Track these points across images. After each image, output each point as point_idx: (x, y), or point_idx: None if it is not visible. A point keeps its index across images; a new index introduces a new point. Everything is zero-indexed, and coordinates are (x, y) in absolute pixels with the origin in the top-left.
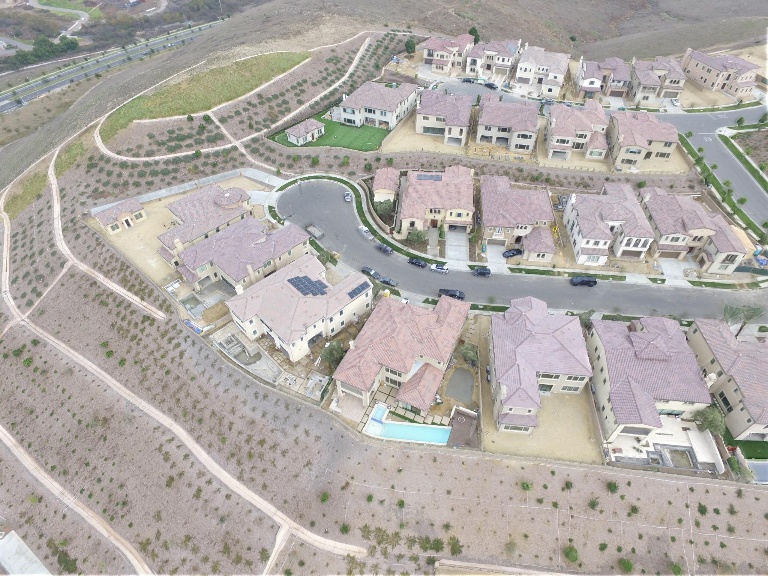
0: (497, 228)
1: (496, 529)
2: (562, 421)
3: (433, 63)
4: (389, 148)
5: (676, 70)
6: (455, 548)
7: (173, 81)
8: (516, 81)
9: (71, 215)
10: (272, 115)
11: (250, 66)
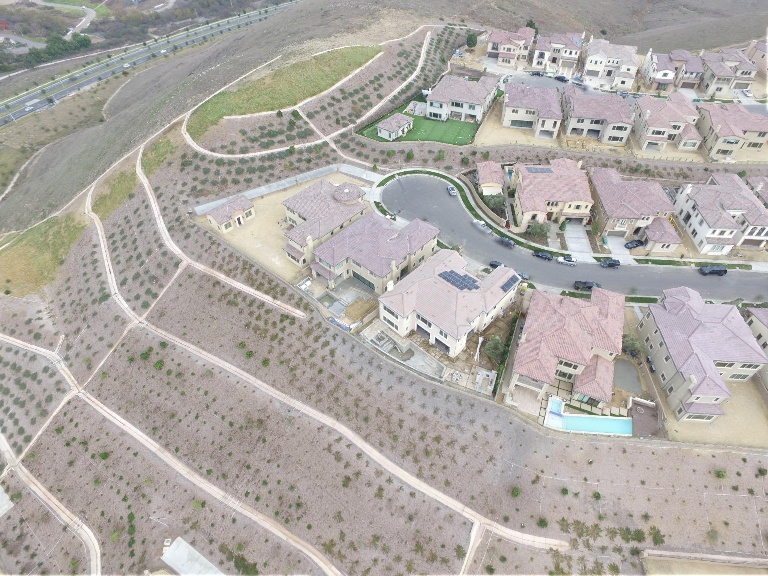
0: (621, 219)
1: (695, 518)
2: (738, 409)
3: (500, 56)
4: (481, 142)
5: (747, 61)
6: (657, 538)
7: (255, 76)
8: (585, 74)
9: (174, 214)
10: (356, 110)
11: (328, 60)
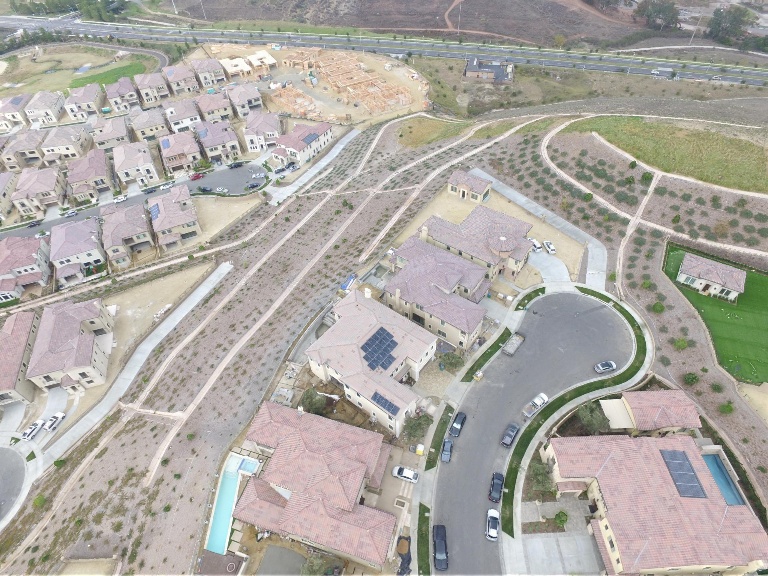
0: None
1: None
2: None
3: None
4: (766, 400)
5: None
6: None
7: (684, 124)
8: None
9: (467, 161)
10: (719, 230)
11: None
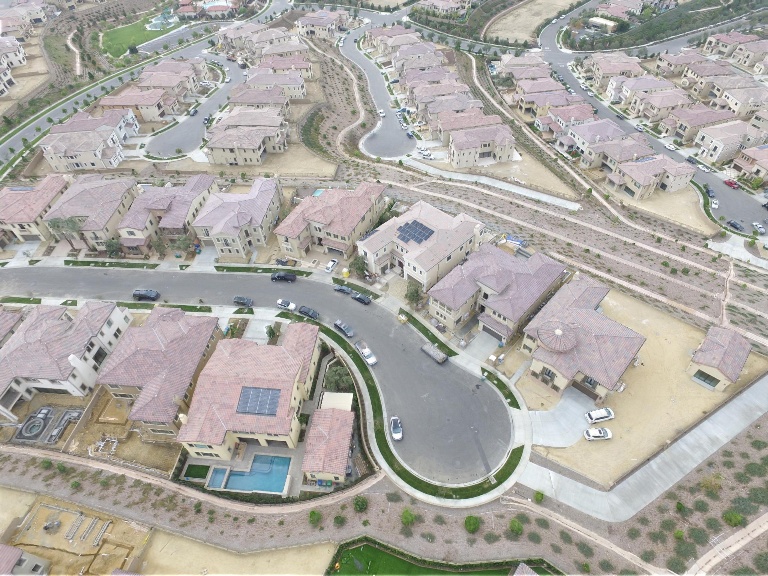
0: None
1: None
2: None
3: None
4: (312, 575)
5: None
6: None
7: None
8: None
9: None
10: None
11: None
